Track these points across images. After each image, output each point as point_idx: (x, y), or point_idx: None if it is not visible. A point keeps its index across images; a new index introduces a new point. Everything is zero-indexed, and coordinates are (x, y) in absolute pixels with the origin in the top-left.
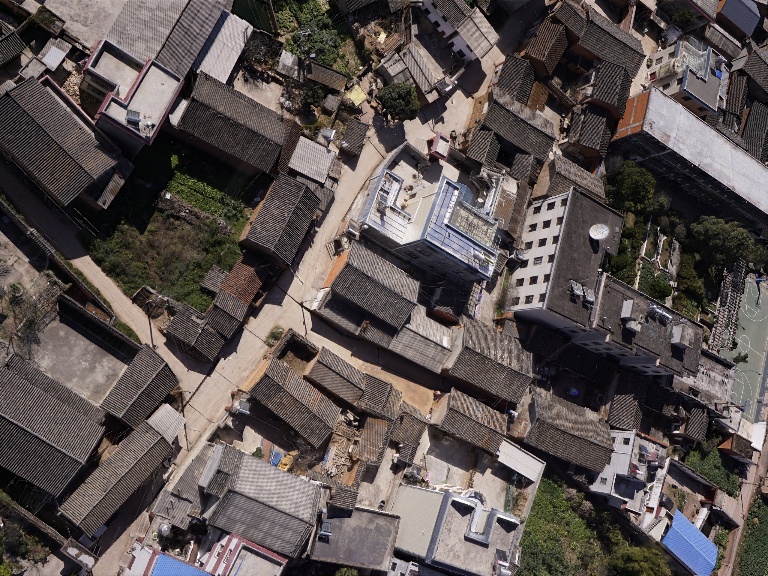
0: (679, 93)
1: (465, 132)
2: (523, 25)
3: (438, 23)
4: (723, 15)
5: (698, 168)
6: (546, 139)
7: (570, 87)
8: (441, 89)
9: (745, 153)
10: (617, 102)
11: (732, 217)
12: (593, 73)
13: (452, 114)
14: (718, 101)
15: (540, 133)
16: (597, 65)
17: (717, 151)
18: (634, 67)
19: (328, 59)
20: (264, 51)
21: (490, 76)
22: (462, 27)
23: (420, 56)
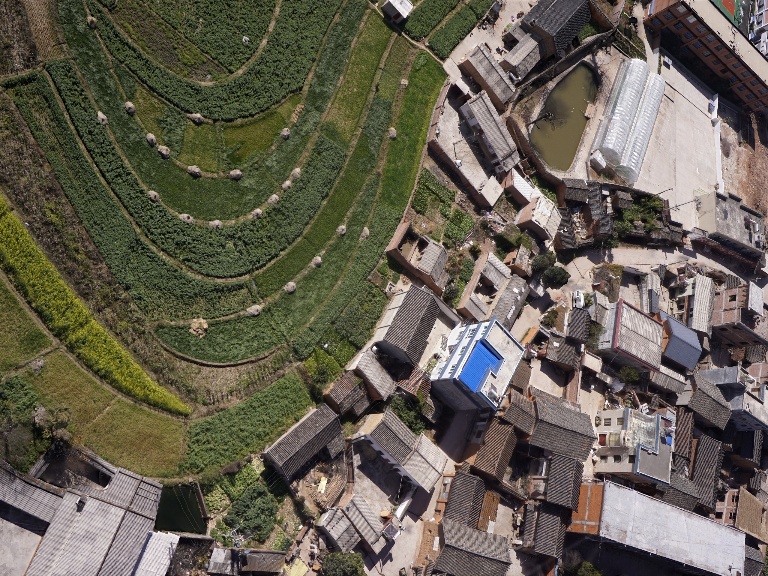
0: (632, 472)
1: (415, 567)
2: (470, 418)
3: (382, 453)
4: (666, 356)
5: (656, 554)
6: (501, 565)
7: (521, 475)
8: (388, 537)
9: (699, 517)
10: (571, 501)
11: (689, 569)
12: (544, 463)
13: (400, 546)
14: (670, 470)
15: (495, 561)
16: (548, 455)
17: (673, 527)
18: (585, 450)
19: (264, 533)
20: (192, 552)
21: (438, 488)
22: (408, 463)
23: (364, 503)
